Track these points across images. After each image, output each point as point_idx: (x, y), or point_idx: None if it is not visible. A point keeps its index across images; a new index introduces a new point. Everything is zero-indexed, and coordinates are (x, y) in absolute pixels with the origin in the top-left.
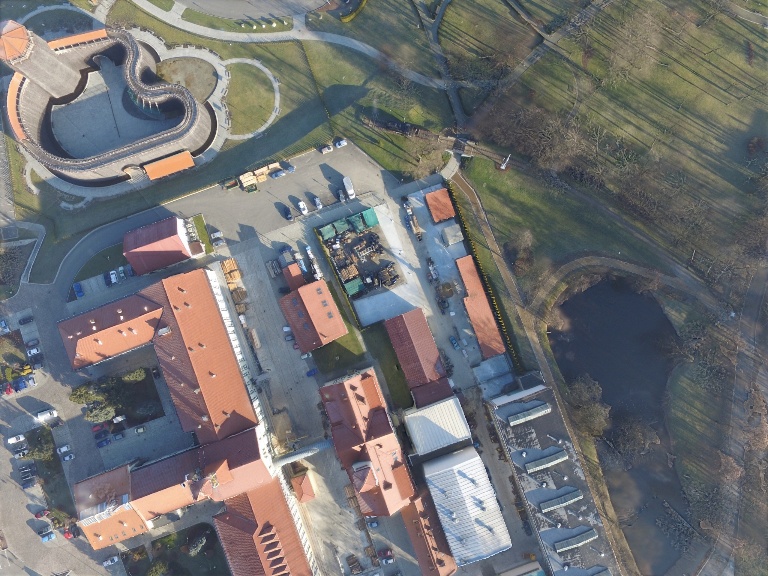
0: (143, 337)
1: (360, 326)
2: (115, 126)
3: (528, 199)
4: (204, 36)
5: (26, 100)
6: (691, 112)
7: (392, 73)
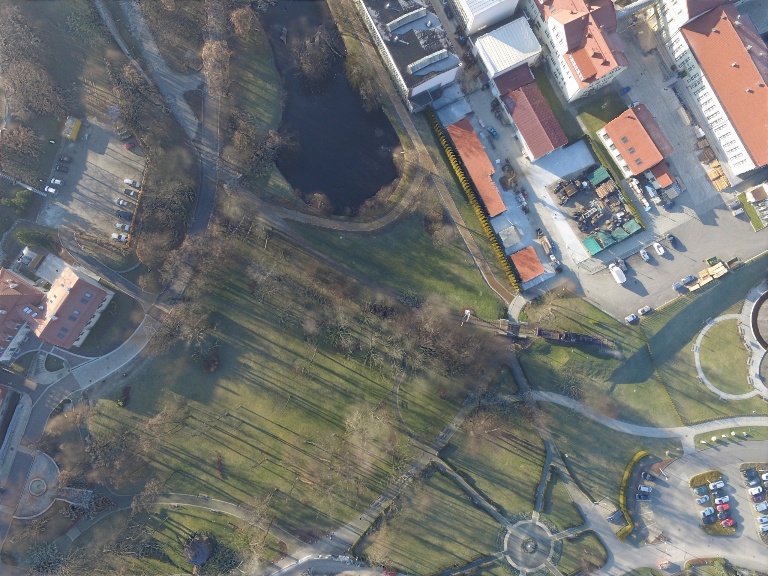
0: None
1: (587, 138)
2: None
3: (436, 284)
4: None
5: None
6: (278, 394)
7: (587, 401)
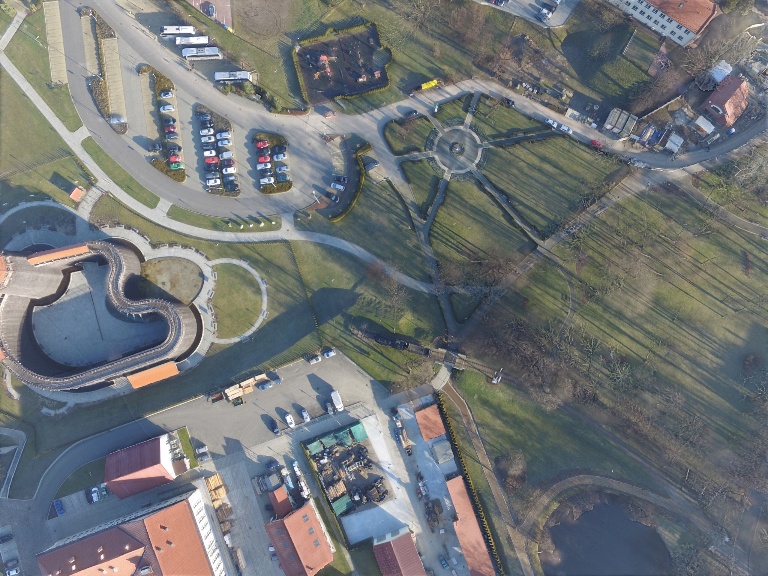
0: (124, 573)
1: (348, 546)
2: (98, 328)
3: (520, 412)
4: (190, 235)
5: (6, 312)
6: (686, 324)
7: (382, 276)
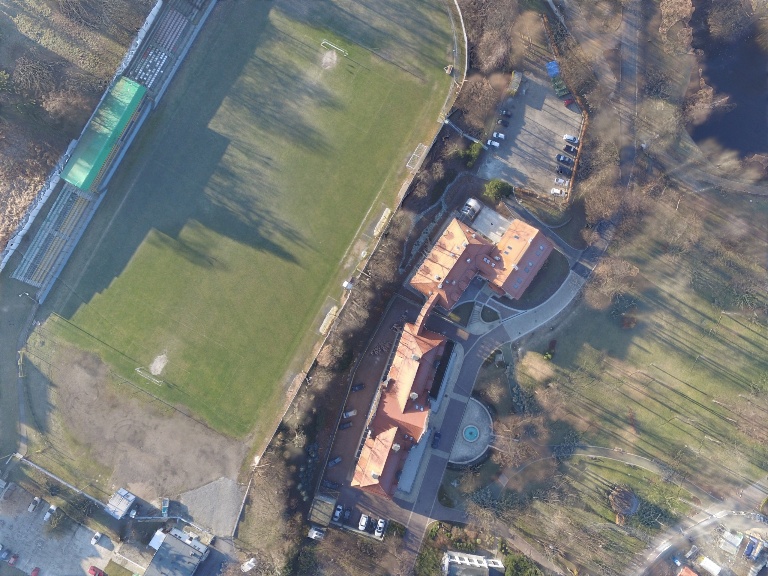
0: None
1: None
2: None
3: None
4: None
5: None
6: (686, 354)
7: None
